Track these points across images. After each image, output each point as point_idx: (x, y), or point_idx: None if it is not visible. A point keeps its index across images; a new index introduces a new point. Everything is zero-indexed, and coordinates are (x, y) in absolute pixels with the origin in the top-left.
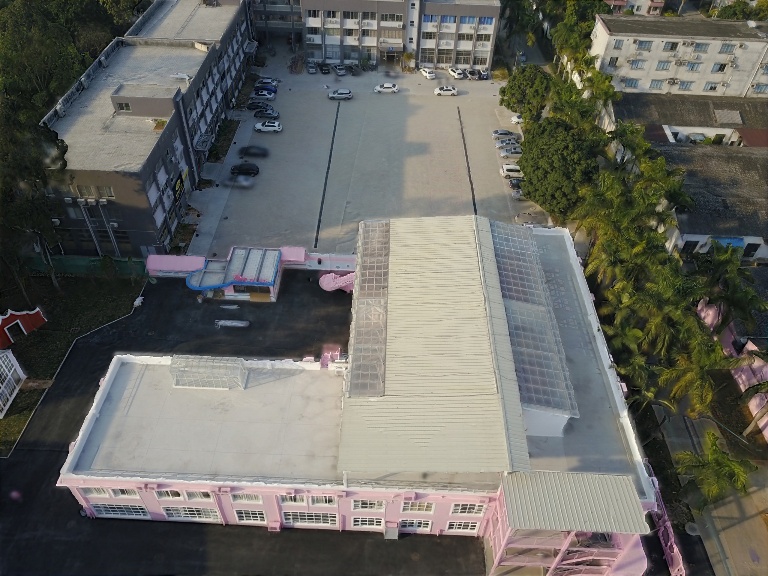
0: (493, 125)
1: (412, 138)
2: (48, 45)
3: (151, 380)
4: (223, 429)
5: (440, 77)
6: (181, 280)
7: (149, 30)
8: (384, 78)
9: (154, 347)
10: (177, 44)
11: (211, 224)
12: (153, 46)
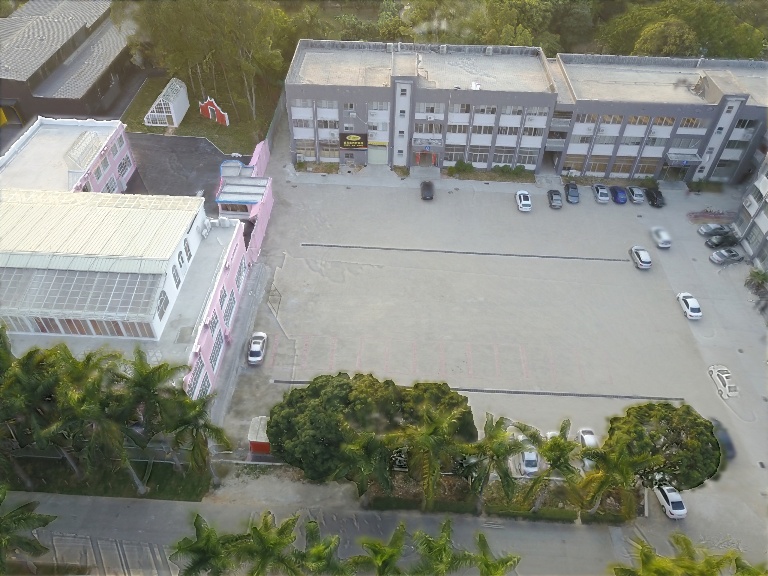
0: None
1: (547, 329)
2: None
3: None
4: (40, 166)
5: None
6: None
7: (597, 67)
8: (736, 307)
9: (186, 167)
10: None
11: (339, 181)
12: (543, 69)
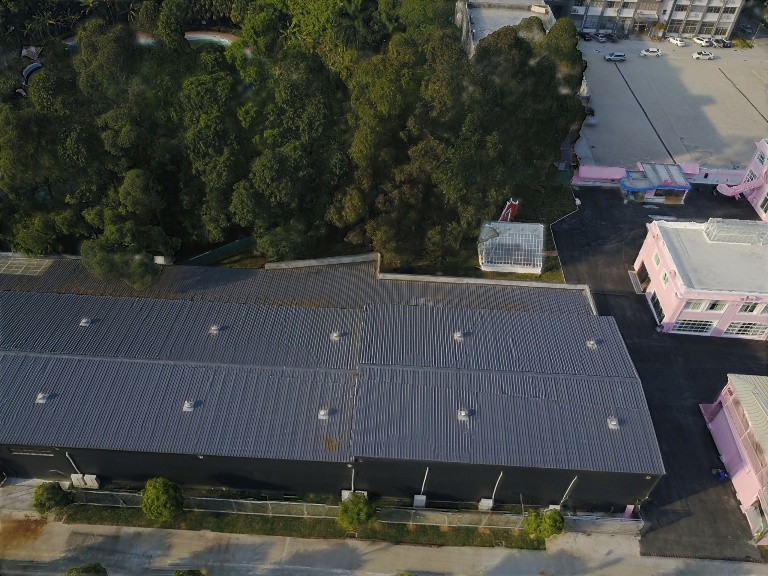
0: (760, 83)
1: (699, 91)
2: (450, 2)
3: (688, 238)
4: None
5: (687, 45)
6: (598, 188)
7: None
8: (640, 45)
9: (615, 232)
10: (516, 7)
11: (585, 151)
12: (494, 8)
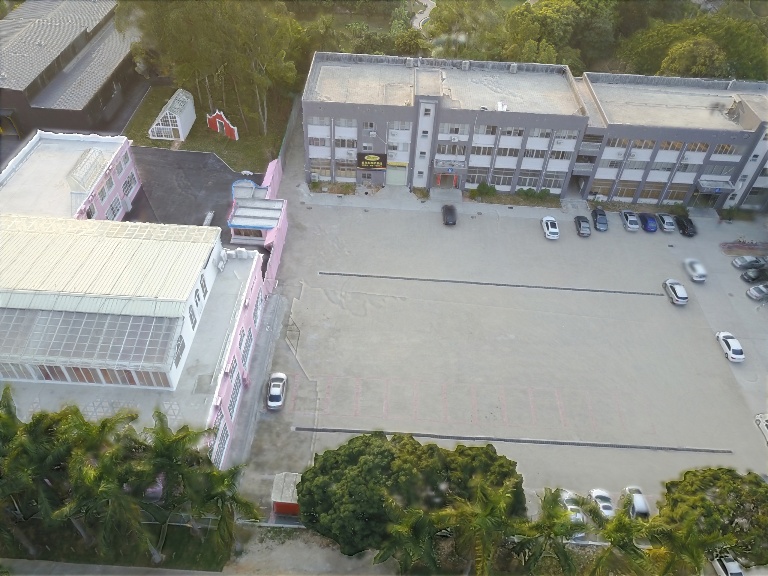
0: None
1: (583, 372)
2: None
3: None
4: (40, 186)
5: None
6: None
7: (625, 88)
8: None
9: (194, 186)
10: None
11: (356, 202)
12: (571, 89)
